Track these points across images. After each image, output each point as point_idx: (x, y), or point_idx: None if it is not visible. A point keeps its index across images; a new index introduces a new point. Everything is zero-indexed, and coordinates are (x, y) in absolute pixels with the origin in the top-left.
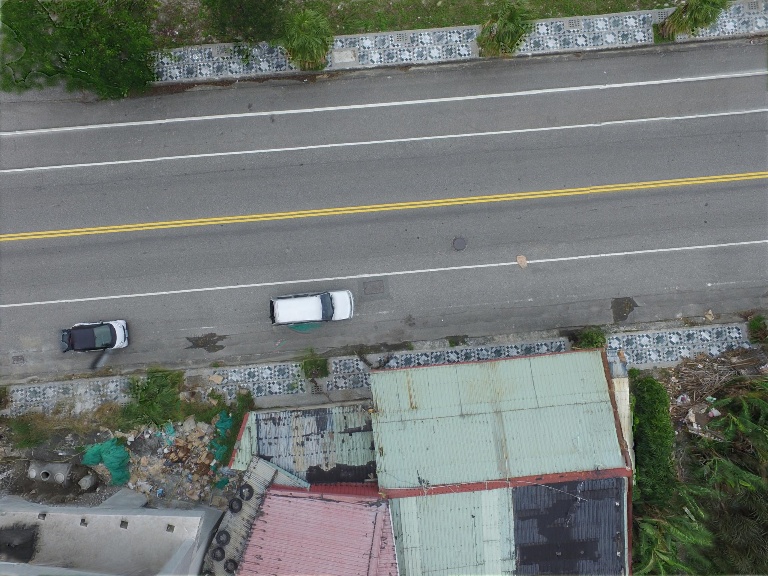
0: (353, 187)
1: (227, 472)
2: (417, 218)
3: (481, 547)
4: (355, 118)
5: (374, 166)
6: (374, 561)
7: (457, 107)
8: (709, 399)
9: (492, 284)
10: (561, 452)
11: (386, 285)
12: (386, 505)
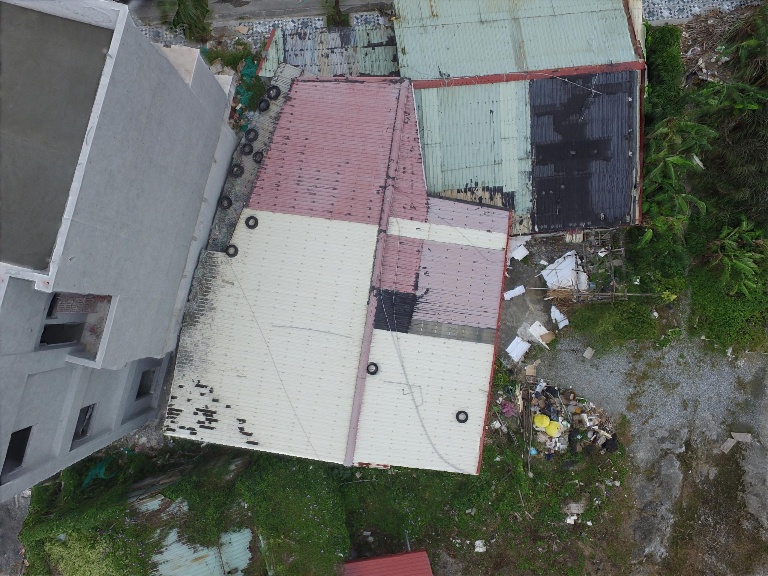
0: None
1: (252, 117)
2: None
3: (499, 146)
4: None
5: None
6: (397, 133)
7: None
8: (718, 49)
9: None
10: (577, 49)
11: None
12: (409, 82)
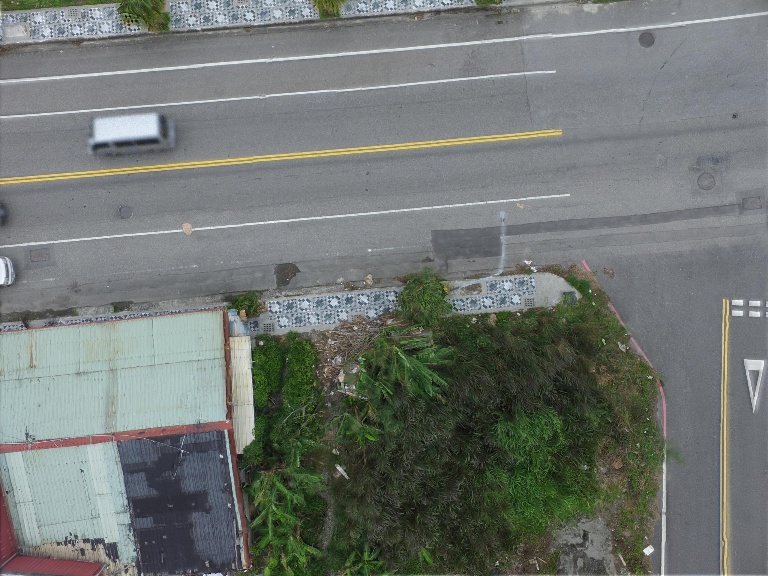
0: (21, 158)
1: None
2: (84, 187)
3: (95, 501)
4: (26, 91)
5: (44, 137)
6: None
7: (127, 80)
8: (360, 360)
9: (158, 251)
10: (167, 407)
11: (52, 253)
12: None
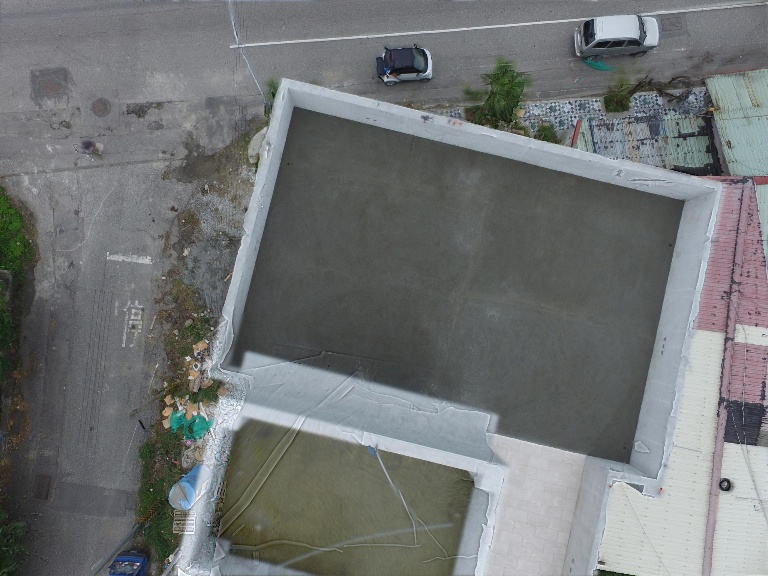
0: None
1: None
2: None
3: None
4: None
5: None
6: (742, 236)
7: None
8: None
9: None
10: None
11: (684, 22)
12: (752, 182)
